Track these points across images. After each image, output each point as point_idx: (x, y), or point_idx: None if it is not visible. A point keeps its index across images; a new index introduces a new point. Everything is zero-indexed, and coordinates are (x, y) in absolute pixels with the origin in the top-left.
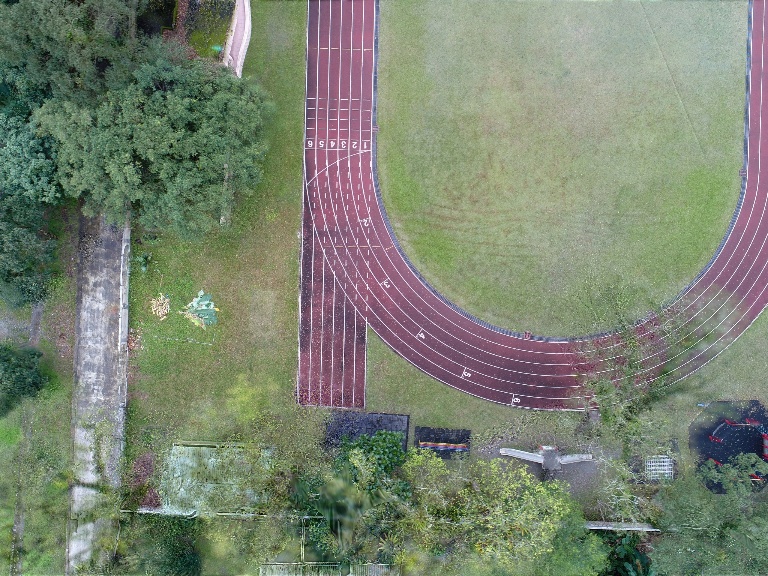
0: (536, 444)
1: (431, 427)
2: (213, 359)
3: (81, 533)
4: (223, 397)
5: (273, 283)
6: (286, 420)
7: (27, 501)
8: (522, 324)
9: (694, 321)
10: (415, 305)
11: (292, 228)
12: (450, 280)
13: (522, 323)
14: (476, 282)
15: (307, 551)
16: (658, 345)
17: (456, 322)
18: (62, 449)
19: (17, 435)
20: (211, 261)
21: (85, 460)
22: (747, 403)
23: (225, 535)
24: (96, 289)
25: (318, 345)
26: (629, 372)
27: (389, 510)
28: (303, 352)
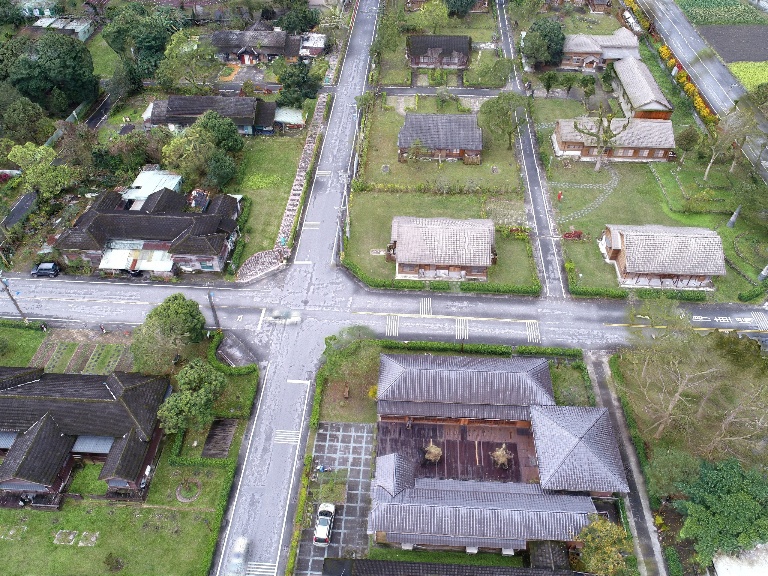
0: None
1: None
2: (58, 0)
3: None
4: None
5: None
6: None
7: None
8: None
9: None
10: None
11: None
12: None
13: None
14: None
15: None
16: None
17: None
18: None
19: None
20: None
21: None
22: (238, 7)
23: None
24: None
25: None
26: None
27: None
28: None
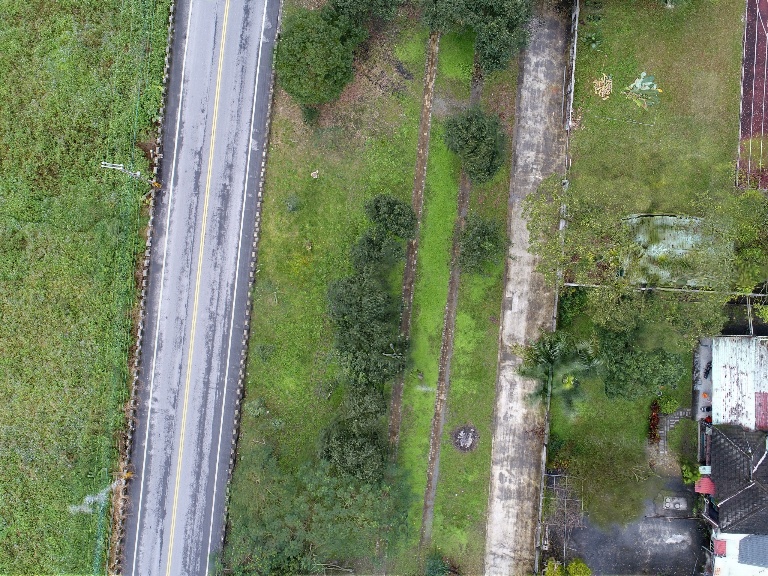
0: None
1: None
2: (654, 140)
3: (515, 311)
4: (663, 178)
5: (716, 66)
6: (725, 202)
7: (461, 279)
8: None
9: None
10: None
11: (736, 11)
12: None
13: None
14: None
15: (755, 326)
16: None
17: None
18: (499, 227)
19: (453, 213)
20: (654, 43)
21: (522, 239)
22: None
23: (660, 315)
24: (538, 69)
25: (759, 128)
26: None
27: None
28: (744, 135)
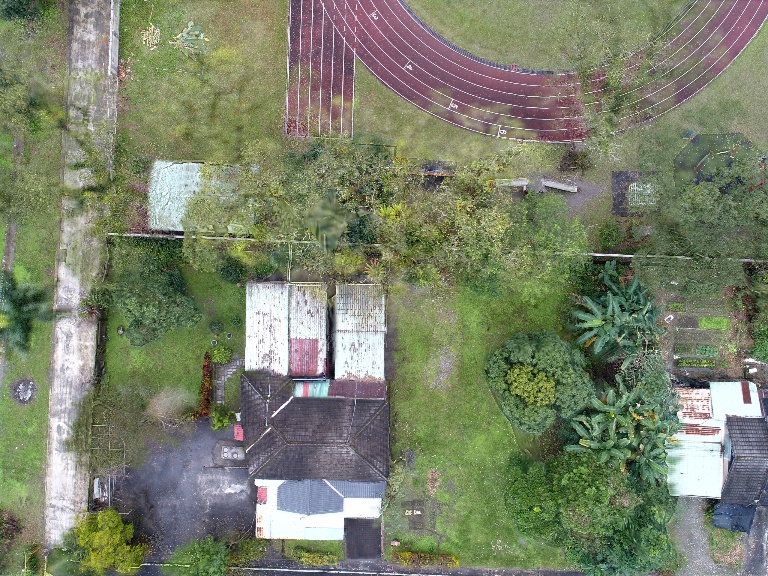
0: (522, 174)
1: (418, 158)
2: (202, 89)
3: (70, 263)
4: (212, 127)
5: (262, 14)
6: (274, 150)
7: (17, 232)
8: (509, 56)
9: (680, 54)
10: (403, 37)
11: None
12: (438, 12)
13: (509, 55)
14: (464, 14)
15: (293, 273)
16: (644, 78)
17: (444, 54)
18: (52, 179)
19: (8, 166)
20: None
21: (75, 190)
22: (732, 136)
23: (213, 265)
24: (87, 20)
25: (307, 76)
26: (615, 104)
27: (375, 235)
28: (292, 83)
